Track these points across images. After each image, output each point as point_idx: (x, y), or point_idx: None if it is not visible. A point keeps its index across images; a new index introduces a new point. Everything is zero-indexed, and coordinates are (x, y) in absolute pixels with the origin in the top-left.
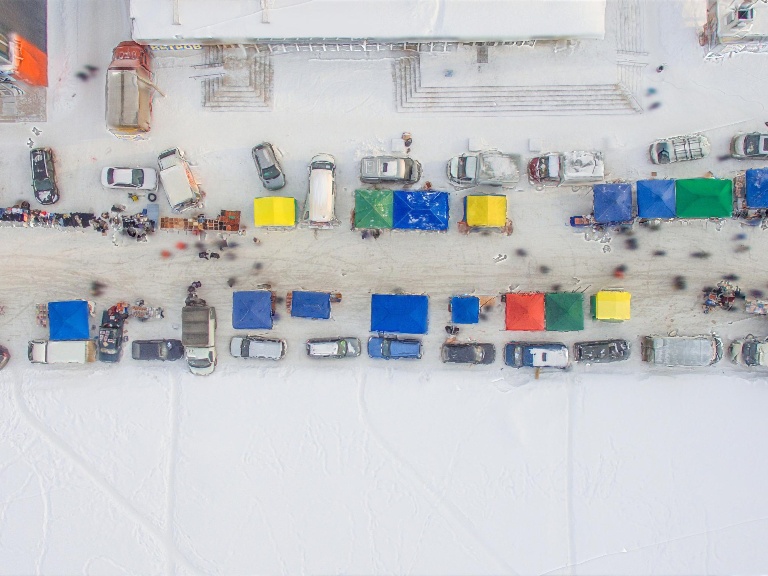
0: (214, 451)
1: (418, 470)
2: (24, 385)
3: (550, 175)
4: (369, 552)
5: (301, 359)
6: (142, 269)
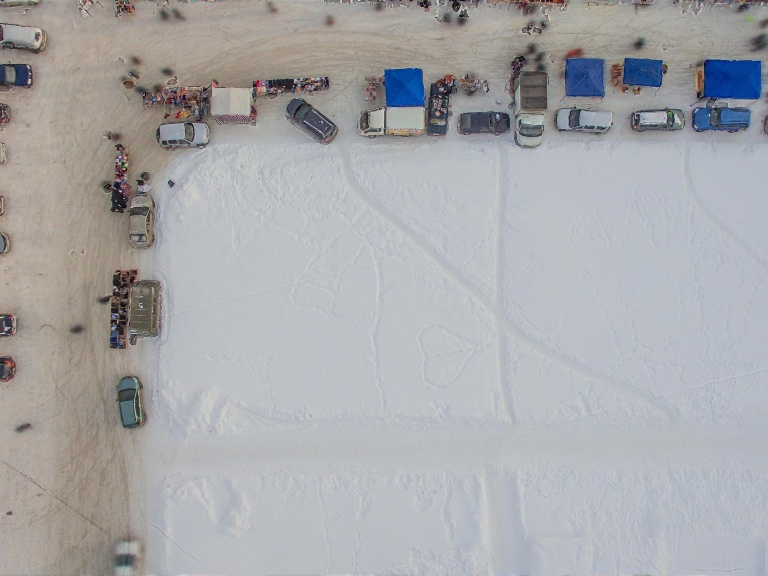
0: (543, 222)
1: (743, 241)
2: (352, 159)
3: None
4: (697, 322)
5: (623, 134)
6: (465, 44)
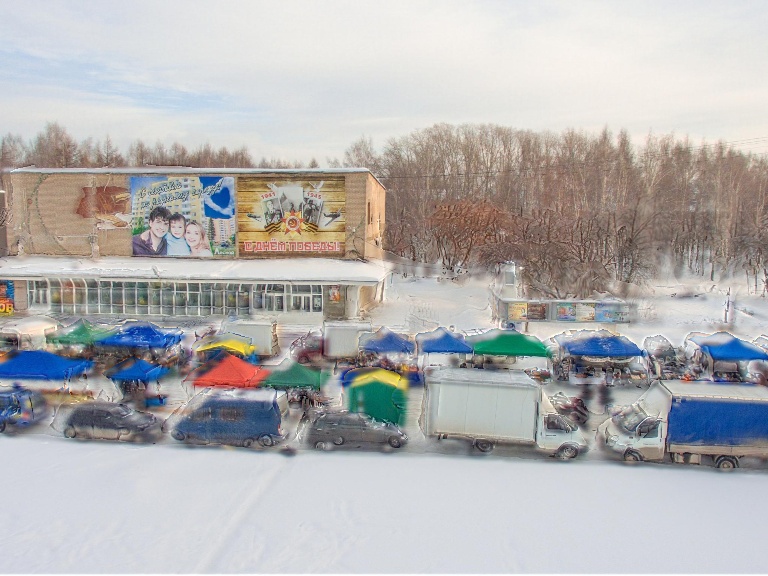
0: None
1: None
2: None
3: (311, 332)
4: None
5: None
6: None
